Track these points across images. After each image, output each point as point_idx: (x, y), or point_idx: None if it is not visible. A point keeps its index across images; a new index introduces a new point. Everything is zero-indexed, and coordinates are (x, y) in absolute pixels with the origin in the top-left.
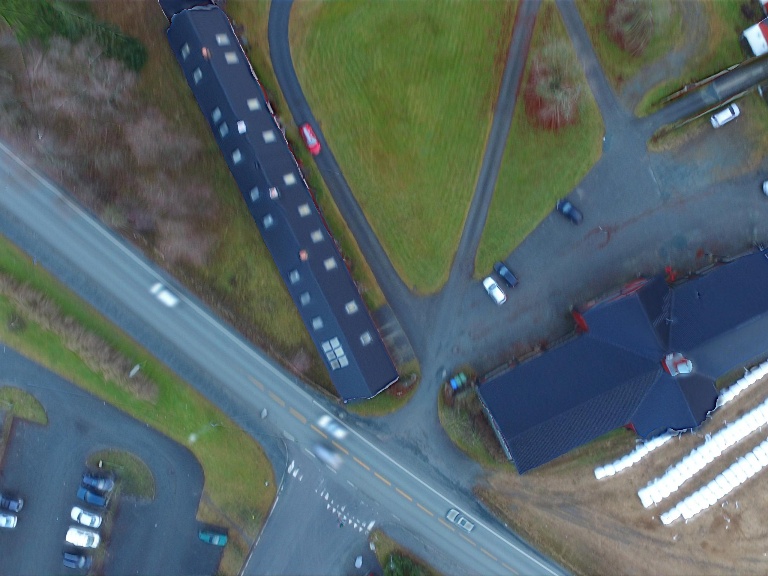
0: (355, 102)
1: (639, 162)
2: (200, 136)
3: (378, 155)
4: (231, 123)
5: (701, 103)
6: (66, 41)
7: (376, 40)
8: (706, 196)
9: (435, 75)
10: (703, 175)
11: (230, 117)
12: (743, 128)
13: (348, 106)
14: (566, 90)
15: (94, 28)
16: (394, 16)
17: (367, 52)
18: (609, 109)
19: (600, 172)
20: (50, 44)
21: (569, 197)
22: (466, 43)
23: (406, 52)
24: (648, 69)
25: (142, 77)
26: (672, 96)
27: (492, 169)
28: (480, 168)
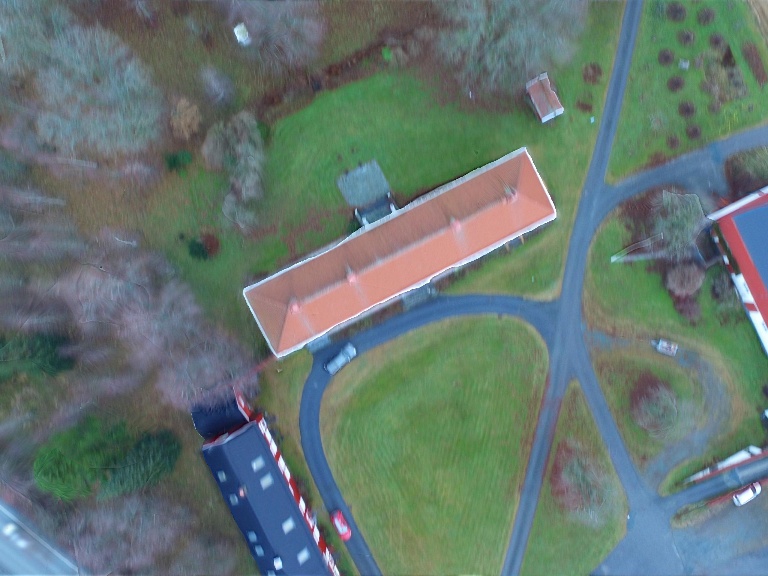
0: (385, 487)
1: (663, 539)
2: (233, 524)
3: (407, 537)
4: (267, 549)
5: (724, 486)
6: (109, 512)
7: (405, 427)
8: (728, 569)
9: (463, 459)
10: (725, 549)
11: (266, 544)
12: (764, 502)
13: (378, 491)
14: (594, 510)
15: (134, 478)
16: (423, 403)
17: (396, 438)
18: (633, 489)
19: (624, 549)
20: (93, 512)
21: (594, 574)
22: (493, 427)
23: (434, 437)
24: (671, 448)
25: (176, 468)
26: (695, 477)
27: (519, 548)
28: (507, 548)
